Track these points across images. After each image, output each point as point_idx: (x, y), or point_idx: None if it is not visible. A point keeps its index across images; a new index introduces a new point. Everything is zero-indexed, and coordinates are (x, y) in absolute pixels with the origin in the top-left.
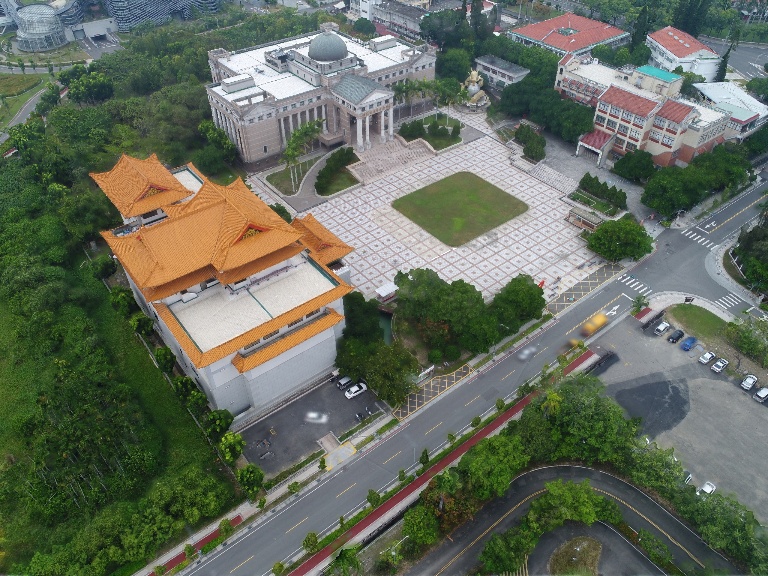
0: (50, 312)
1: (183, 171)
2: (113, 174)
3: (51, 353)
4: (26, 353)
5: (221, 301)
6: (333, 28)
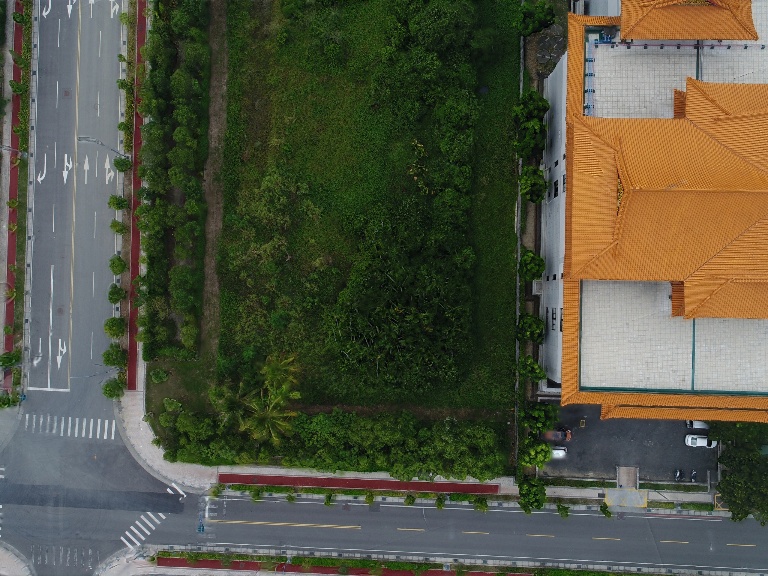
0: (438, 63)
1: None
2: None
3: (414, 121)
4: (388, 97)
5: (650, 302)
6: None
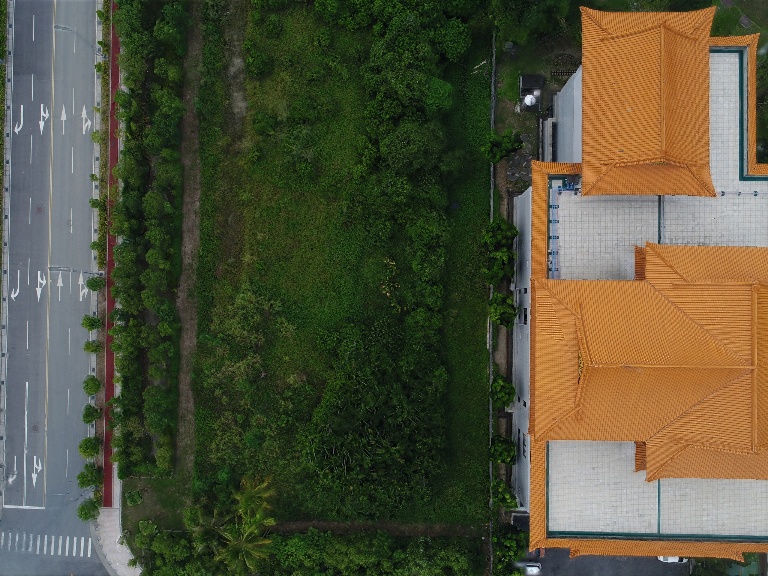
0: (408, 187)
1: (731, 54)
2: (618, 46)
3: (386, 239)
4: (360, 214)
5: (616, 447)
6: None
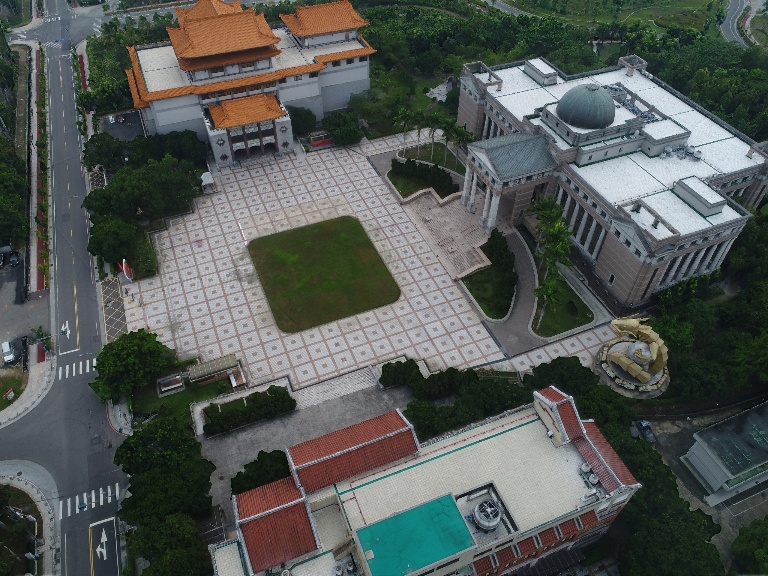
0: None
1: None
2: None
3: None
4: None
5: None
6: (761, 153)
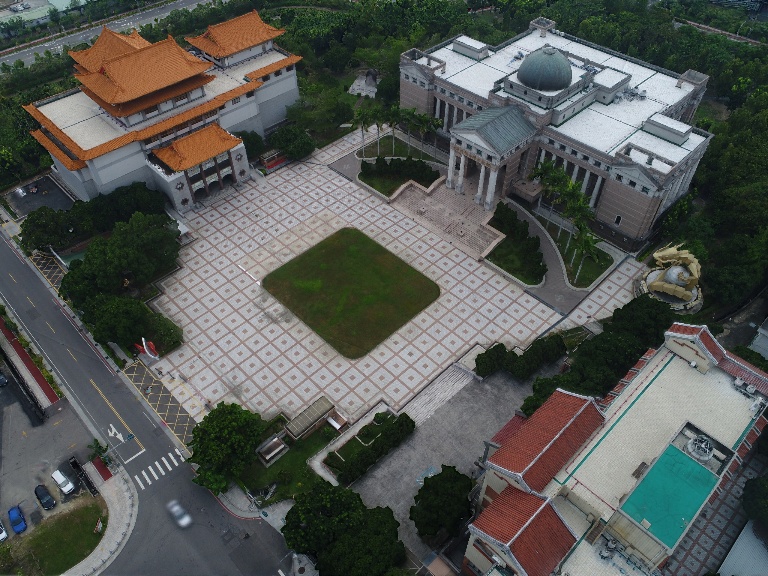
0: None
1: None
2: None
3: None
4: None
5: (93, 104)
6: (690, 82)
